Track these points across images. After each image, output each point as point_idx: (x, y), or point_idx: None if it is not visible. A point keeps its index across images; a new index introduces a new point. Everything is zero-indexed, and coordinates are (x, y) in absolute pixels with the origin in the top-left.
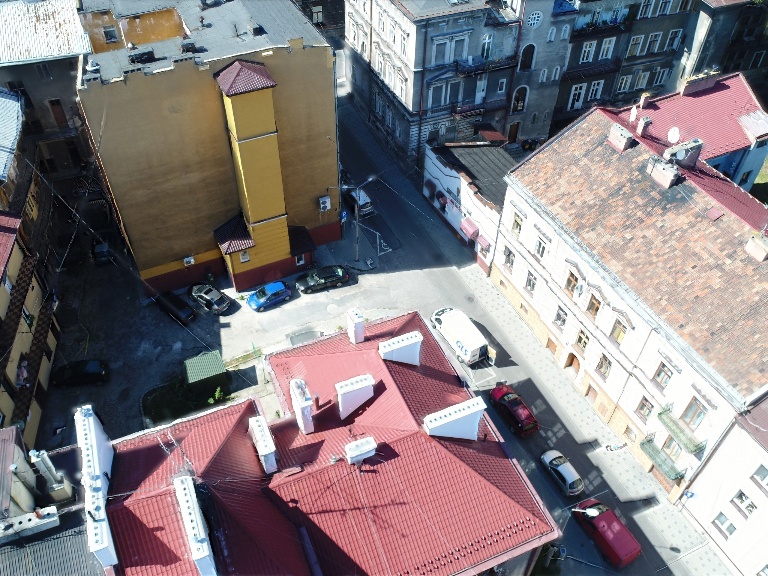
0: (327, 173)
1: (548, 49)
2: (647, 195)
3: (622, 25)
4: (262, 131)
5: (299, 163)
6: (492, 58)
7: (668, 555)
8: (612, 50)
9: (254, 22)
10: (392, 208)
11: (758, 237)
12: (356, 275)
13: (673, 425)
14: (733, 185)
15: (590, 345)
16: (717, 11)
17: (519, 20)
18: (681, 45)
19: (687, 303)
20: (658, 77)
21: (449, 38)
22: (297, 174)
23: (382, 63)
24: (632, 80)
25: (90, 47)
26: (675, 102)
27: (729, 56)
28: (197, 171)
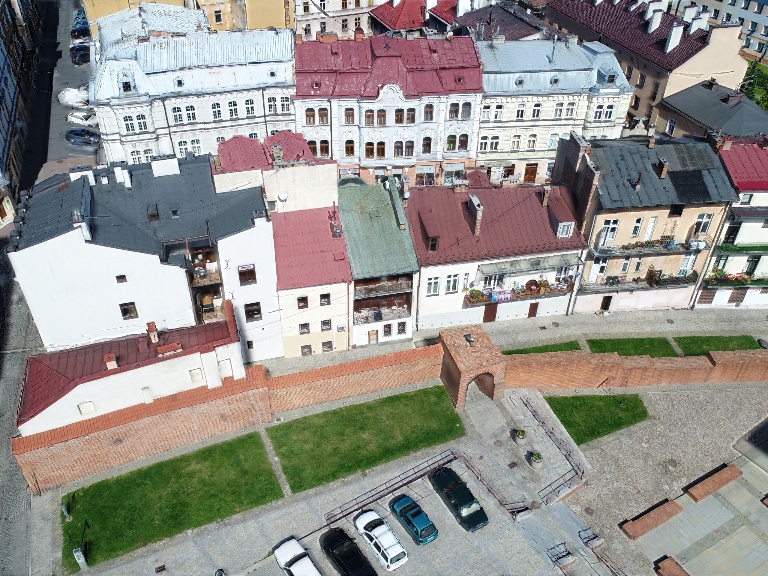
0: None
1: None
2: None
3: None
4: None
5: None
6: None
7: None
8: None
9: None
10: None
11: None
12: None
13: None
14: None
15: None
16: None
17: None
18: None
19: None
20: None
21: None
22: None
23: None
24: None
25: None
26: None
27: None
28: None
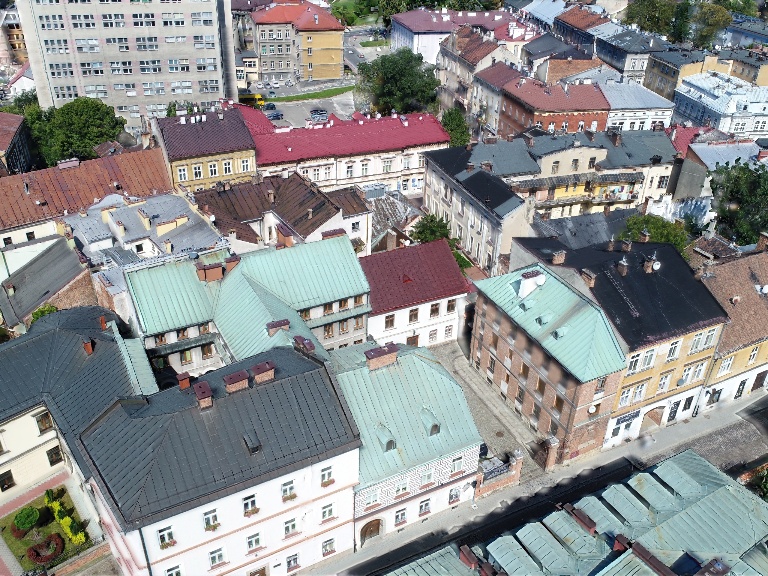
0: None
1: None
2: None
3: None
4: None
5: None
6: None
7: None
8: None
9: None
10: None
11: (765, 47)
12: None
13: None
14: None
15: None
16: None
17: None
18: None
19: None
20: None
21: None
22: None
23: None
24: None
25: None
26: None
27: None
28: None
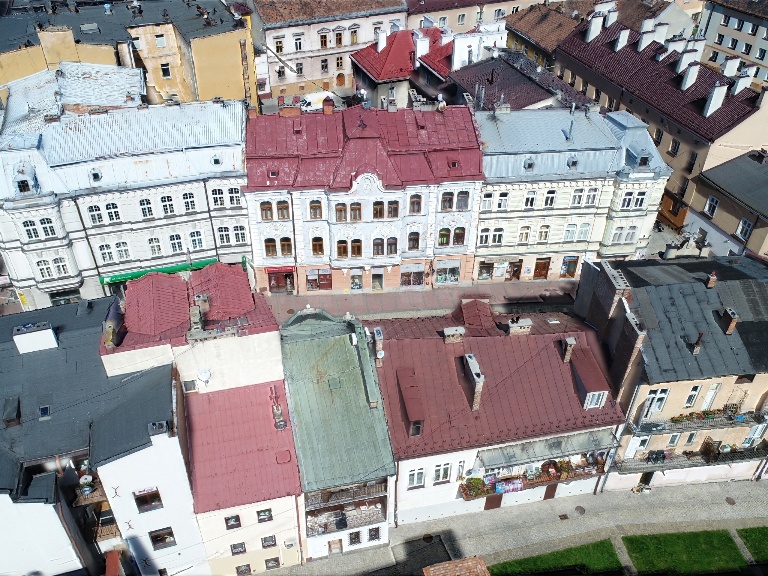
0: None
1: None
2: None
3: None
4: None
5: None
6: None
7: None
8: None
9: None
10: None
11: None
12: None
13: None
14: None
15: (345, 59)
16: None
17: None
18: None
19: (363, 2)
20: None
21: None
22: None
23: None
24: None
25: (135, 68)
26: None
27: None
28: None
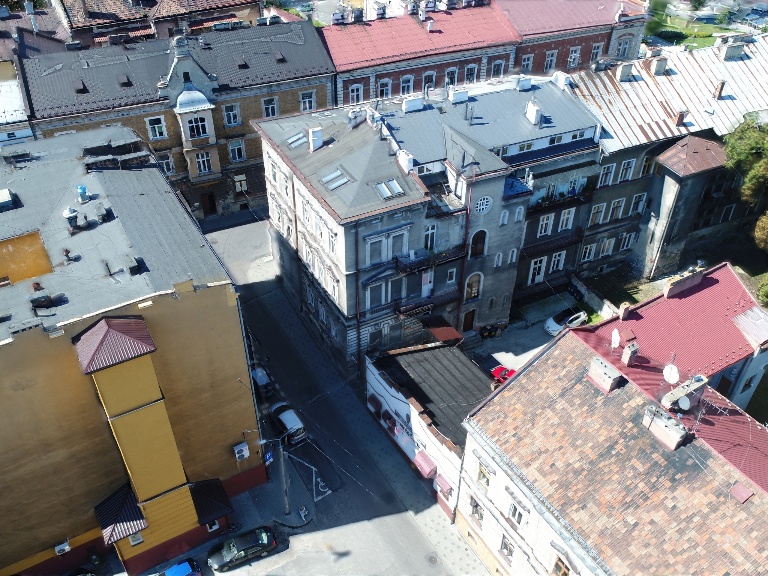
0: (241, 417)
1: (501, 233)
2: (648, 458)
3: (581, 196)
4: (142, 401)
5: (203, 413)
6: (437, 249)
7: None
8: (572, 220)
9: (131, 258)
10: (330, 429)
11: None
12: (286, 535)
13: None
14: (746, 418)
15: None
16: (684, 177)
17: (465, 208)
18: (647, 209)
19: None
20: (624, 242)
21: (385, 235)
22: (201, 425)
23: (310, 255)
24: (596, 248)
25: None
26: (659, 307)
27: (698, 214)
28: (62, 448)
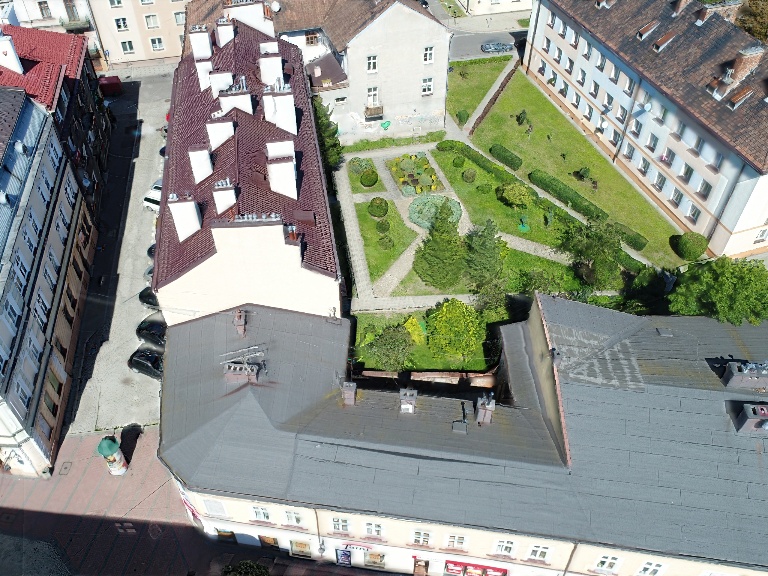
0: None
1: None
2: None
3: None
4: None
5: None
6: None
7: (129, 80)
8: None
9: None
10: None
11: None
12: None
13: (71, 24)
14: None
15: None
16: None
17: None
18: None
19: None
20: None
21: None
22: None
23: None
24: None
25: None
26: None
27: None
28: None
